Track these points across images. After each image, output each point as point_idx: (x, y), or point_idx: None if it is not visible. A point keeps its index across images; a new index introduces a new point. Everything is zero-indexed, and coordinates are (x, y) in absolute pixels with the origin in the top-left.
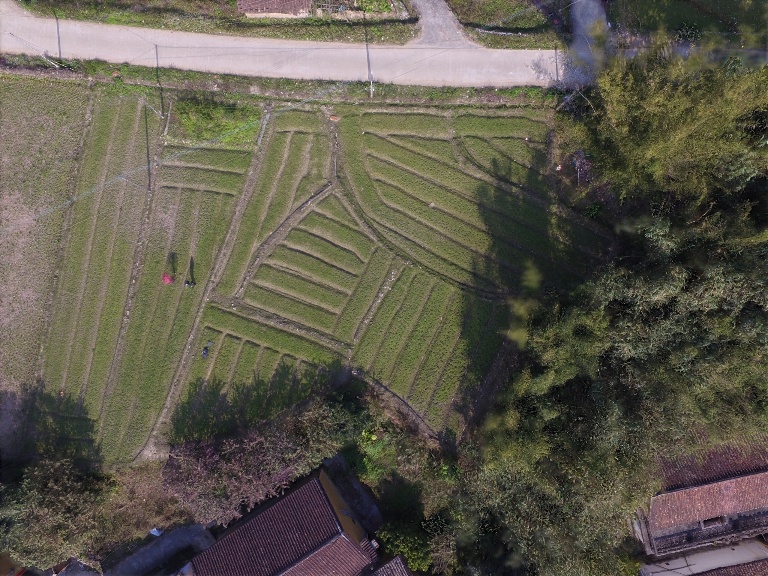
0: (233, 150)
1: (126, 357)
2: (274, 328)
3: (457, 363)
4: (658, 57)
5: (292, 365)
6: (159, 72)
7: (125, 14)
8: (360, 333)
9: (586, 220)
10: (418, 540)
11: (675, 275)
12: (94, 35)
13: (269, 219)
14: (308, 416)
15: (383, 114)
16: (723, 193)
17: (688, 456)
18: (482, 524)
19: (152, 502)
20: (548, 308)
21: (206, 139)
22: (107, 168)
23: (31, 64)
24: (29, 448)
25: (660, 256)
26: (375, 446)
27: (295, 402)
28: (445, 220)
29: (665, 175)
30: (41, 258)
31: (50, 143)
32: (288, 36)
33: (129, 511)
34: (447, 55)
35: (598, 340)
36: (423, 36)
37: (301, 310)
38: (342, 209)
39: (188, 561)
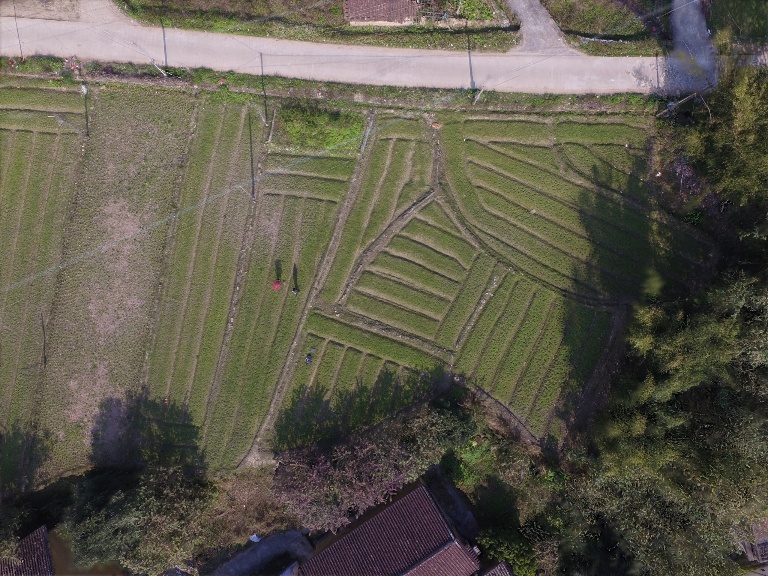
0: (336, 157)
1: (230, 364)
2: (377, 335)
3: (559, 369)
4: (759, 64)
5: (395, 372)
6: (264, 80)
7: (231, 23)
8: (462, 340)
9: (687, 226)
10: (523, 547)
11: None
12: (200, 43)
13: (372, 226)
14: (418, 423)
15: (484, 121)
16: None
17: None
18: (581, 530)
19: (252, 508)
20: (671, 315)
21: (310, 146)
22: (211, 176)
23: (138, 72)
24: (134, 455)
25: None
26: (474, 452)
27: (398, 409)
28: (546, 227)
29: None
30: (146, 265)
31: (155, 151)
32: (391, 44)
33: (229, 517)
34: (549, 62)
35: (728, 348)
36: (525, 43)
37: (404, 317)
38: (444, 216)
39: (286, 567)
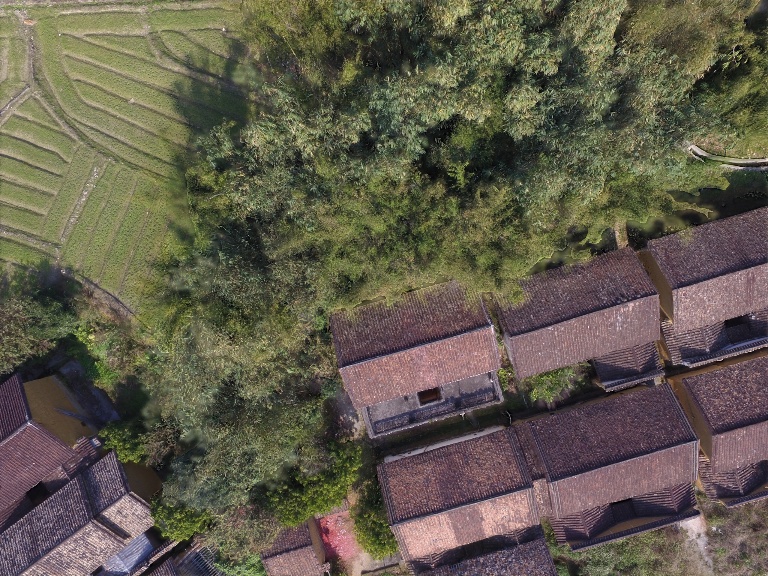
0: None
1: None
2: None
3: None
4: None
5: (1, 268)
6: None
7: None
8: (67, 232)
9: None
10: (127, 432)
11: (263, 115)
12: None
13: None
14: None
15: (78, 14)
16: (355, 46)
17: (381, 328)
18: None
19: None
20: None
21: None
22: None
23: None
24: None
25: (271, 105)
26: (99, 347)
27: None
28: (145, 115)
29: (287, 29)
30: None
31: None
32: None
33: None
34: None
35: (216, 194)
36: None
37: (7, 213)
38: (42, 111)
39: None
